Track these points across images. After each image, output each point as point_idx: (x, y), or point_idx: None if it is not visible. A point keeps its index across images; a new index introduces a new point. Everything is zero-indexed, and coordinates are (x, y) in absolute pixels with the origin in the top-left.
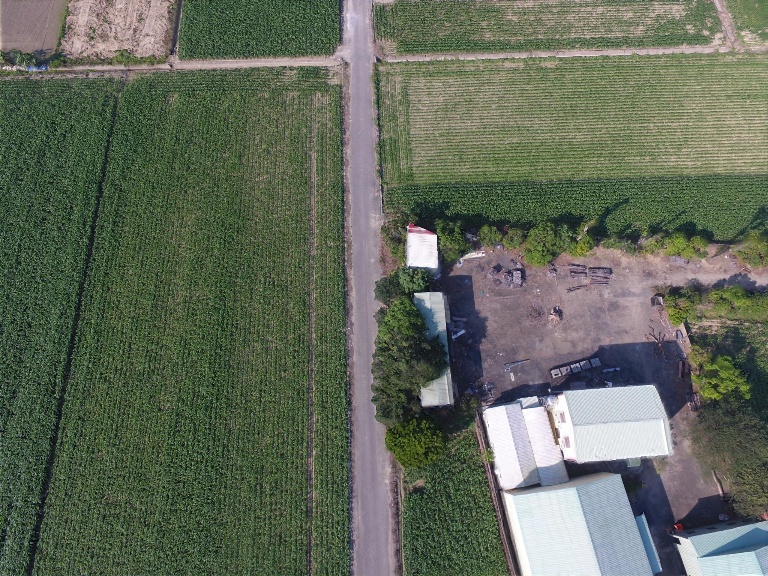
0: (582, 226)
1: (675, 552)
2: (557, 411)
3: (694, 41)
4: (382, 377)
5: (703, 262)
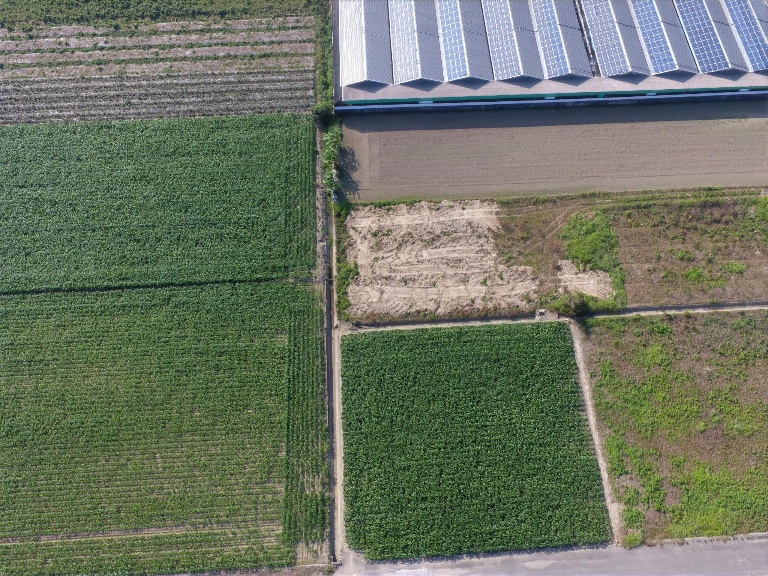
0: None
1: None
2: None
3: None
4: None
5: None
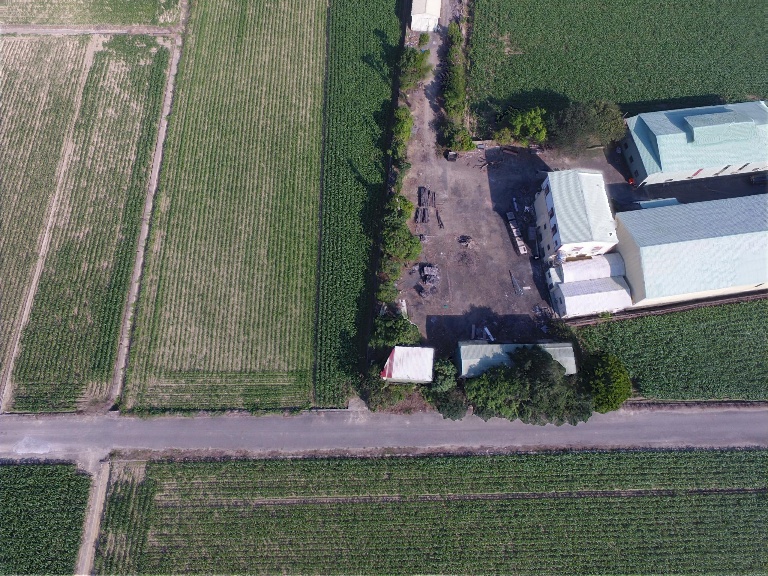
0: (396, 202)
1: (648, 187)
2: (567, 253)
3: (164, 63)
4: (551, 414)
5: (413, 114)
